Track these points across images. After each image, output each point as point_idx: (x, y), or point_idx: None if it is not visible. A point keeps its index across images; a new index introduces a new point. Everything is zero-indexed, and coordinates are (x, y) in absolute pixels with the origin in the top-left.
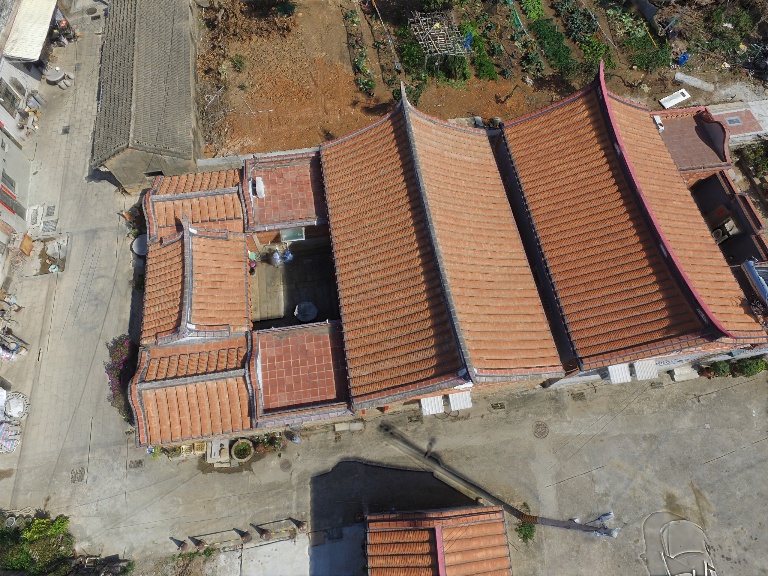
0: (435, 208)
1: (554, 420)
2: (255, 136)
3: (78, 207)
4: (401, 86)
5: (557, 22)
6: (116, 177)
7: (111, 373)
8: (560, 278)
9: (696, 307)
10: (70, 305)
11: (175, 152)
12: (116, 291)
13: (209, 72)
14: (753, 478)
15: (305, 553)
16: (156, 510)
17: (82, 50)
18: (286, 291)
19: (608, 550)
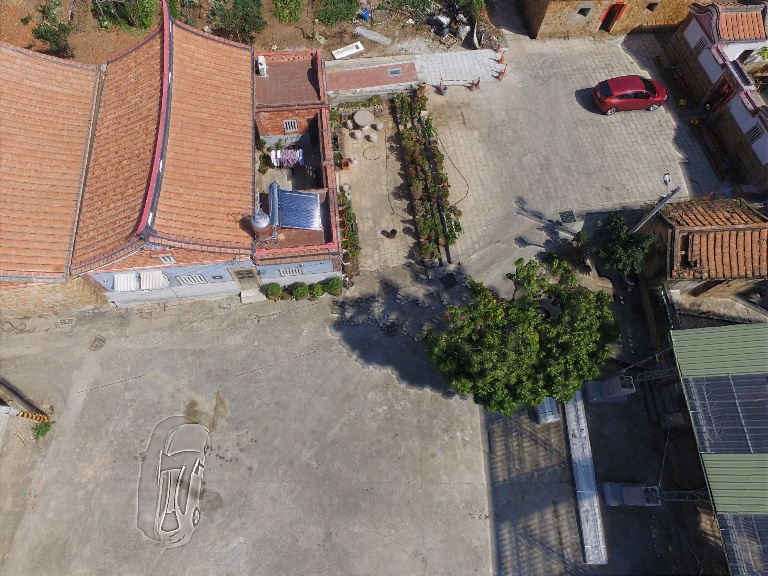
0: None
1: (113, 335)
2: None
3: None
4: None
5: None
6: None
7: None
8: (90, 195)
9: None
10: None
11: None
12: None
13: None
14: (277, 389)
15: None
16: None
17: None
18: None
19: (111, 448)
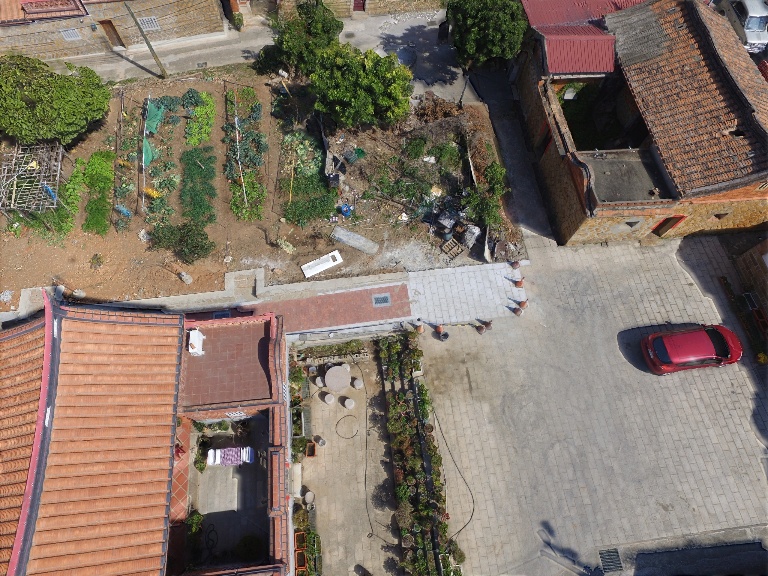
0: None
1: None
2: None
3: None
4: None
5: (221, 150)
6: None
7: None
8: None
9: None
10: None
11: None
12: None
13: None
14: None
15: None
16: None
17: None
18: None
19: None
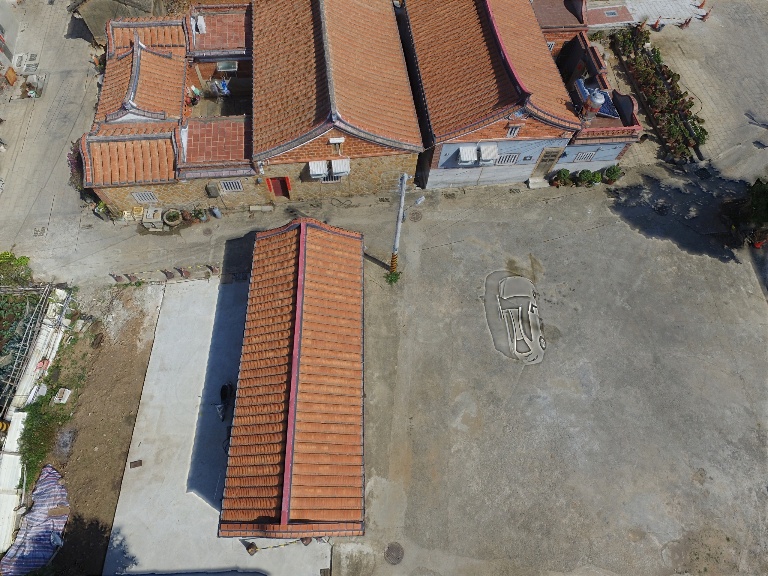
0: (332, 27)
1: (427, 210)
2: None
3: (56, 55)
4: None
5: None
6: (88, 26)
7: (71, 156)
8: (429, 85)
9: (516, 85)
10: (43, 121)
11: (137, 3)
12: (82, 113)
13: None
14: (580, 252)
15: (216, 288)
16: (100, 256)
17: None
18: None
19: (455, 292)
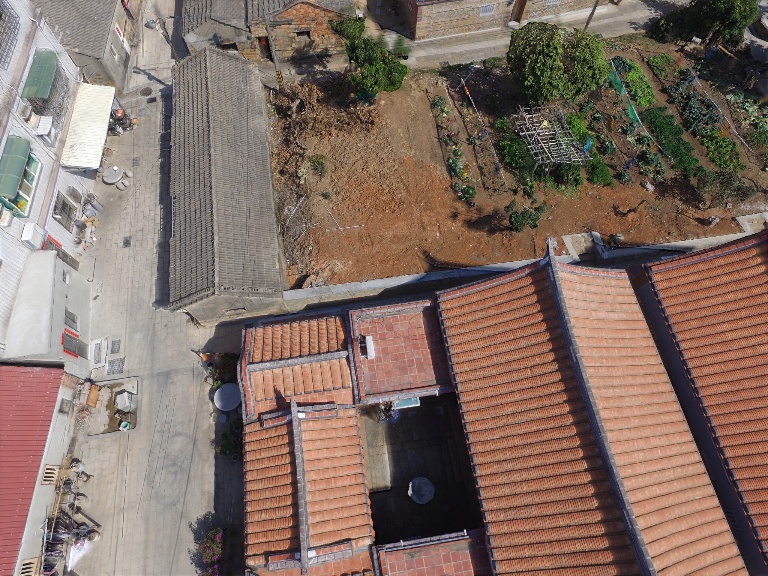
0: (598, 401)
1: None
2: (345, 258)
3: (146, 342)
4: (549, 244)
5: (671, 110)
6: (193, 315)
7: None
8: (749, 487)
9: None
10: (145, 472)
11: (264, 293)
12: (196, 454)
13: (285, 173)
14: None
15: None
16: None
17: (139, 140)
18: (391, 454)
19: None
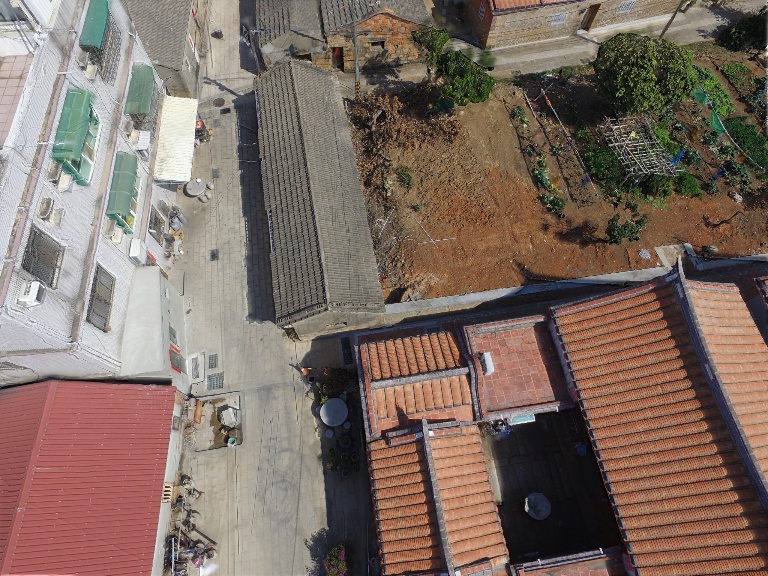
0: None
1: None
2: (440, 272)
3: (244, 356)
4: (678, 260)
5: (750, 119)
6: (296, 330)
7: None
8: None
9: None
10: (255, 489)
11: (371, 308)
12: (305, 469)
13: (370, 185)
14: None
15: None
16: None
17: (217, 152)
18: (499, 468)
19: None
